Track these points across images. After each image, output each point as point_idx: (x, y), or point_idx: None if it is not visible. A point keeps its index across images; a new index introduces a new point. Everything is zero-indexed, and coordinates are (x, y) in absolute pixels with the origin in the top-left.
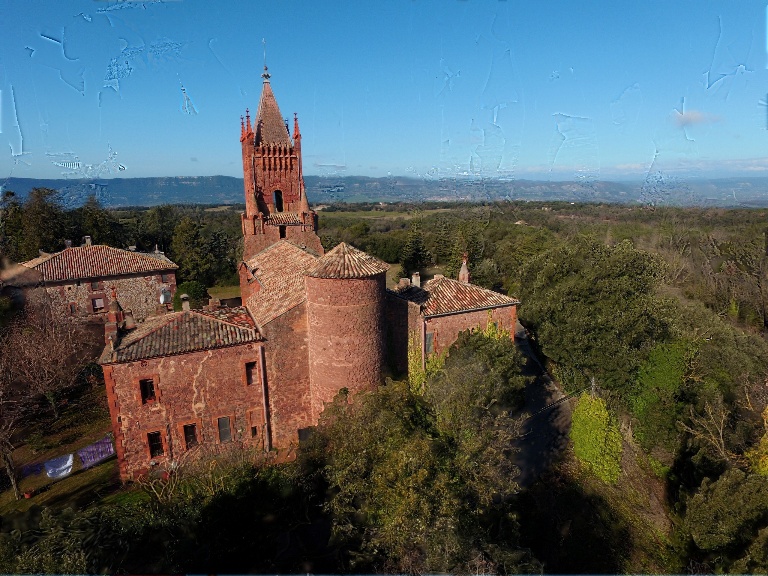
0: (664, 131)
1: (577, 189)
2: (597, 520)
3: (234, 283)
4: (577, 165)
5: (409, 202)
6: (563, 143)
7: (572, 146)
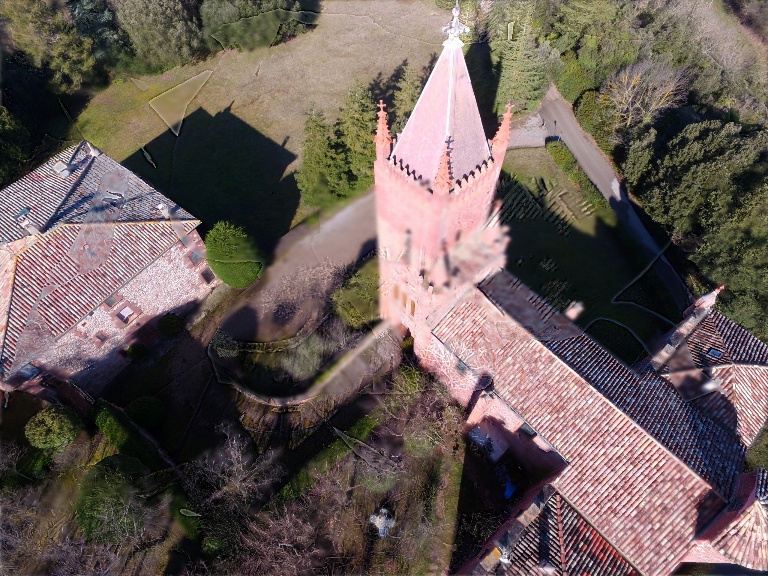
0: None
1: None
2: None
3: (140, 72)
4: None
5: None
6: None
7: None
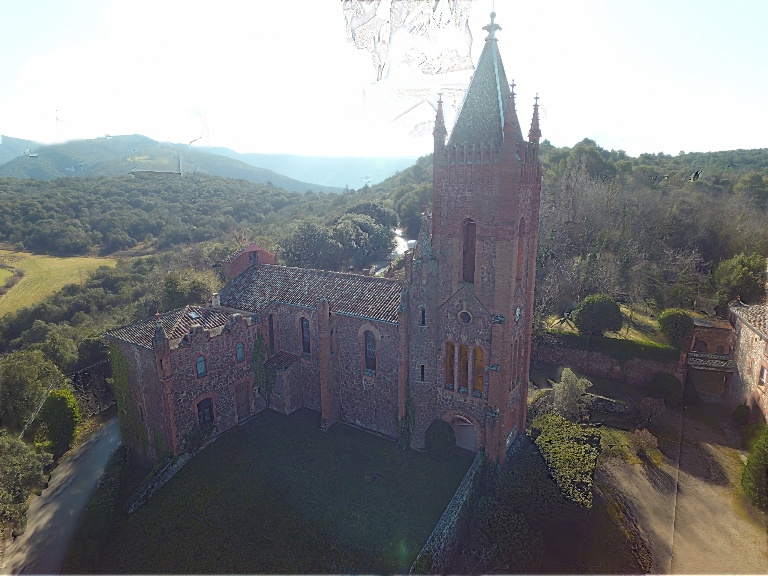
0: None
1: None
2: None
3: None
4: None
5: None
6: None
7: None
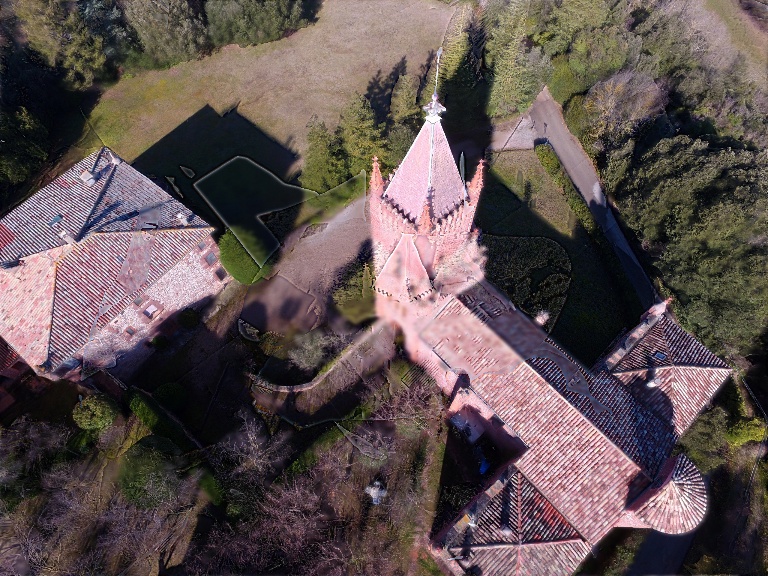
0: None
1: None
2: (743, 492)
3: (148, 67)
4: None
5: (461, 1)
6: None
7: None
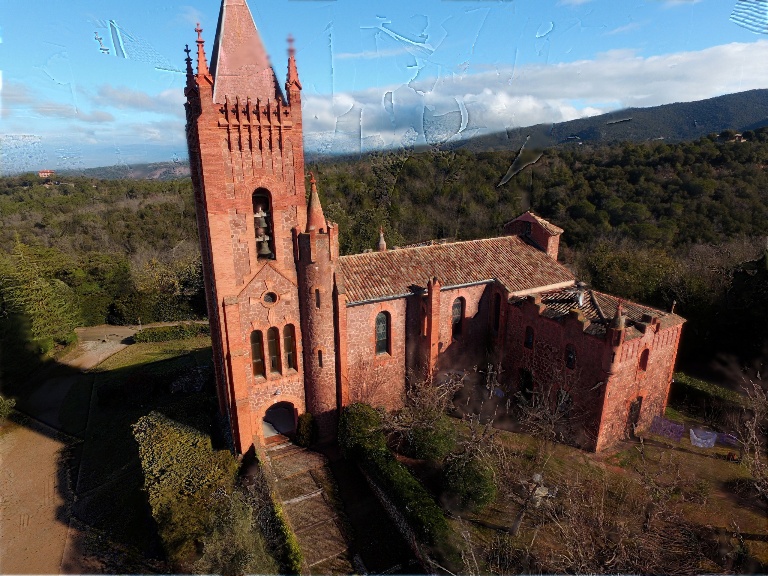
0: (169, 116)
1: (63, 172)
2: None
3: None
4: (55, 143)
5: None
6: (2, 111)
7: (39, 118)
